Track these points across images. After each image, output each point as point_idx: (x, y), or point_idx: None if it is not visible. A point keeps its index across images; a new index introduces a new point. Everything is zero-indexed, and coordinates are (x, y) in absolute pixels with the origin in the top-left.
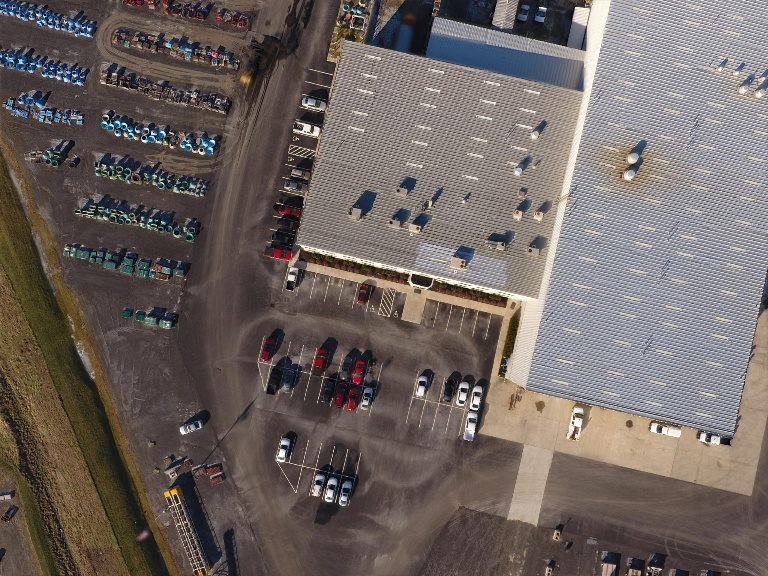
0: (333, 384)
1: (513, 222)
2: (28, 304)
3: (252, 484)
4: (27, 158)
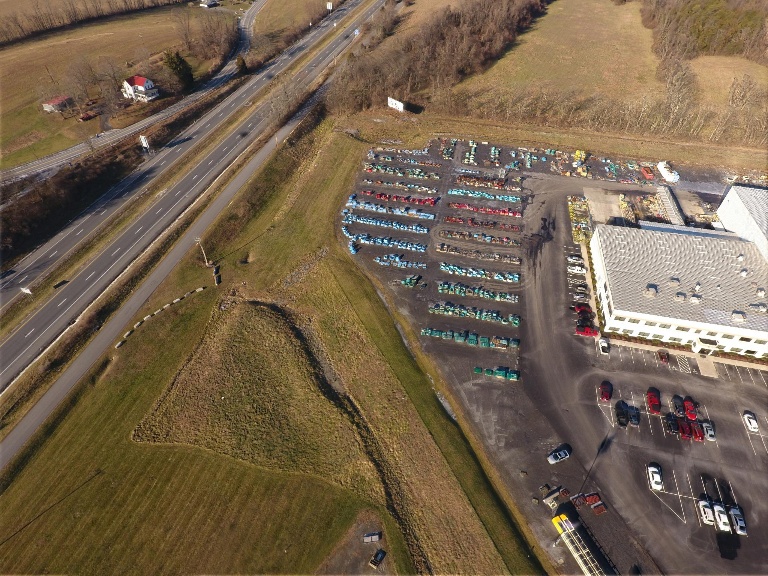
0: (673, 420)
1: (760, 298)
2: (396, 364)
3: (637, 514)
4: (390, 283)
